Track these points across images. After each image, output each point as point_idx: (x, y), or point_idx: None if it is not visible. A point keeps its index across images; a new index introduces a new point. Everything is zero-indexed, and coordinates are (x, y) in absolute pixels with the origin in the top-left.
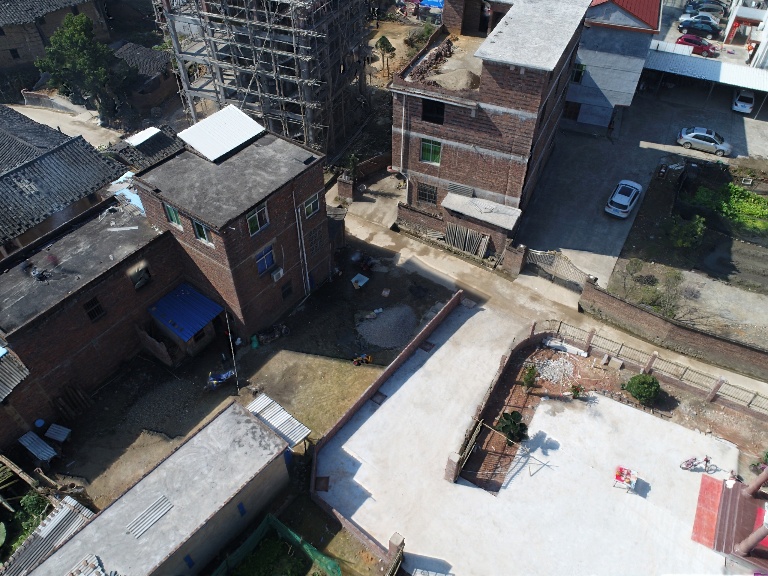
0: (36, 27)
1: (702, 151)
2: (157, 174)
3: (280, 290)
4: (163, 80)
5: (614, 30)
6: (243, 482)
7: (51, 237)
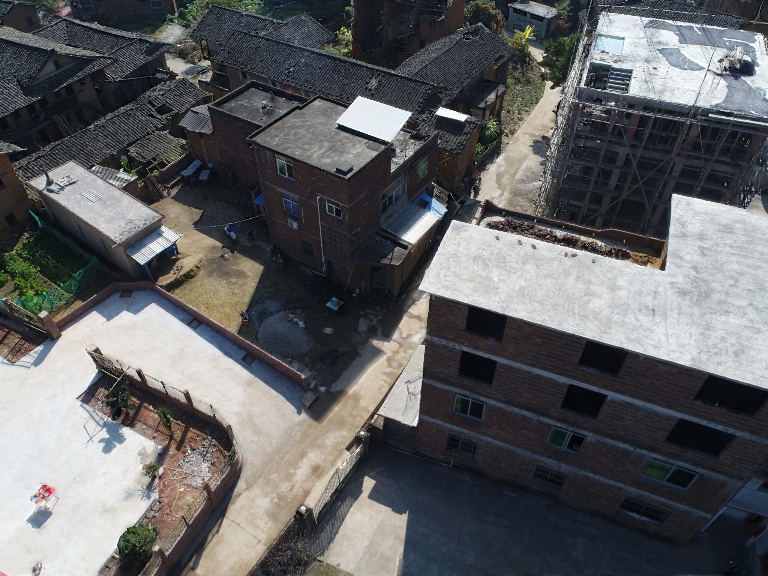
0: None
1: None
2: (323, 105)
3: (301, 241)
4: None
5: None
6: (99, 227)
7: (305, 101)
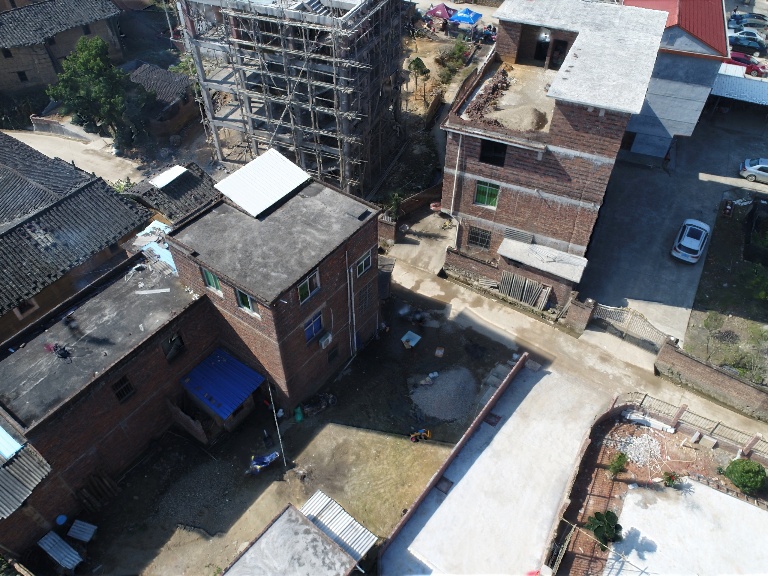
0: (45, 48)
1: (767, 184)
2: (193, 233)
3: (326, 355)
4: (182, 105)
5: (678, 56)
6: None
7: (72, 302)
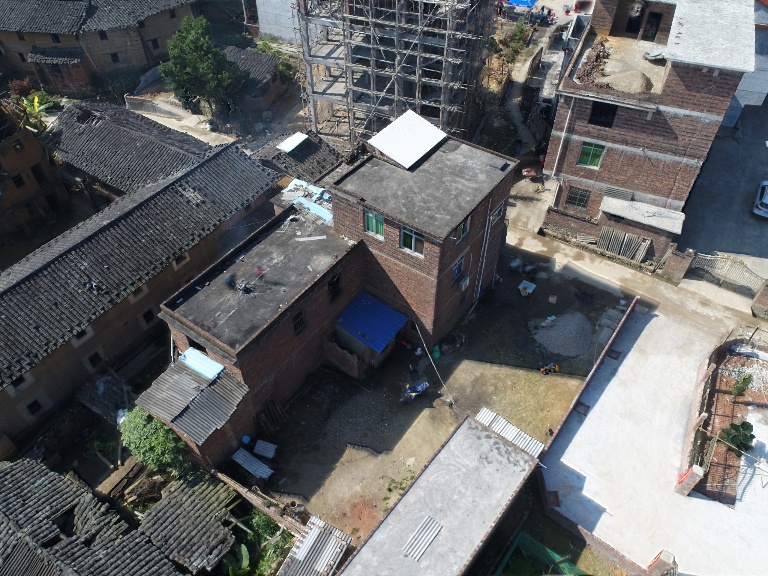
0: (137, 30)
1: None
2: (354, 182)
3: (459, 299)
4: (272, 83)
5: None
6: (505, 500)
7: (241, 248)
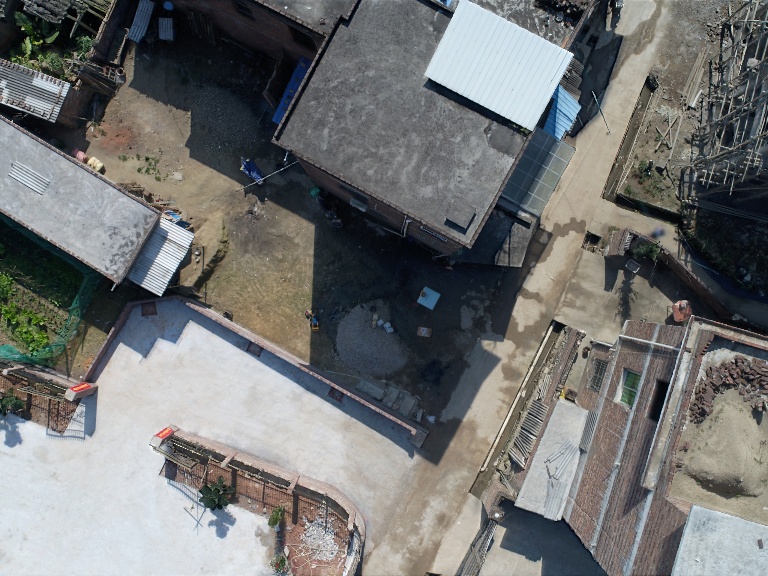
0: None
1: None
2: (387, 2)
3: None
4: None
5: None
6: (73, 251)
7: None
